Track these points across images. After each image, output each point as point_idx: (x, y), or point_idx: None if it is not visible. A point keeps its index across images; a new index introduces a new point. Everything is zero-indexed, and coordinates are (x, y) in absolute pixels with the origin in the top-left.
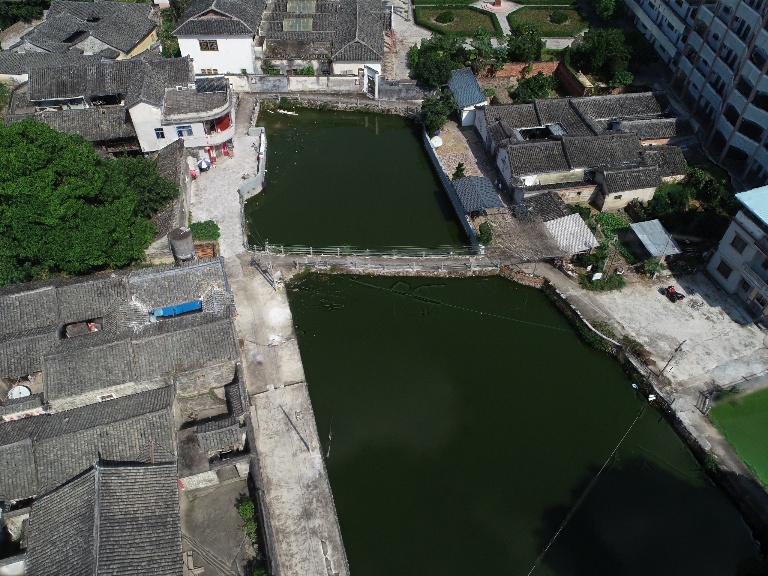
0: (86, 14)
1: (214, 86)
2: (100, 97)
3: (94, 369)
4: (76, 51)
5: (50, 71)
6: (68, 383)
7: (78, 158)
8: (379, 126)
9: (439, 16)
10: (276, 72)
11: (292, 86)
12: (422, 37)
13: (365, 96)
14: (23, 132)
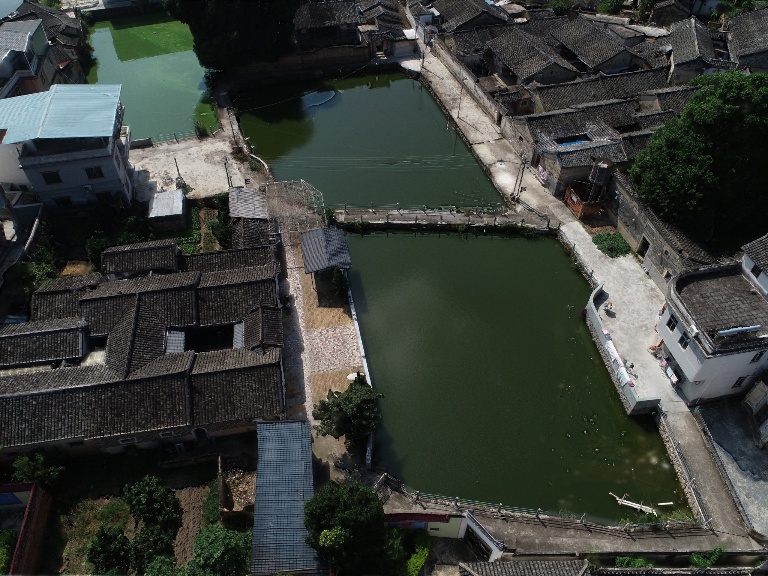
0: None
1: None
2: None
3: None
4: None
5: None
6: None
7: None
8: None
9: None
10: (704, 555)
11: None
12: None
13: None
14: None
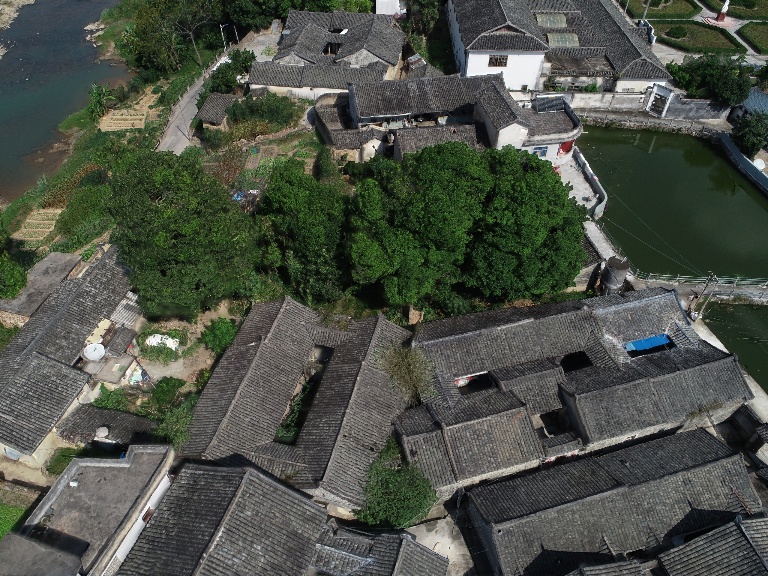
0: (326, 25)
1: (553, 105)
2: (424, 114)
3: (626, 409)
4: (345, 64)
5: (373, 87)
6: (606, 424)
7: (557, 186)
8: (655, 145)
9: (672, 31)
10: (562, 89)
11: (574, 103)
12: (665, 53)
13: (648, 114)
14: (521, 160)
